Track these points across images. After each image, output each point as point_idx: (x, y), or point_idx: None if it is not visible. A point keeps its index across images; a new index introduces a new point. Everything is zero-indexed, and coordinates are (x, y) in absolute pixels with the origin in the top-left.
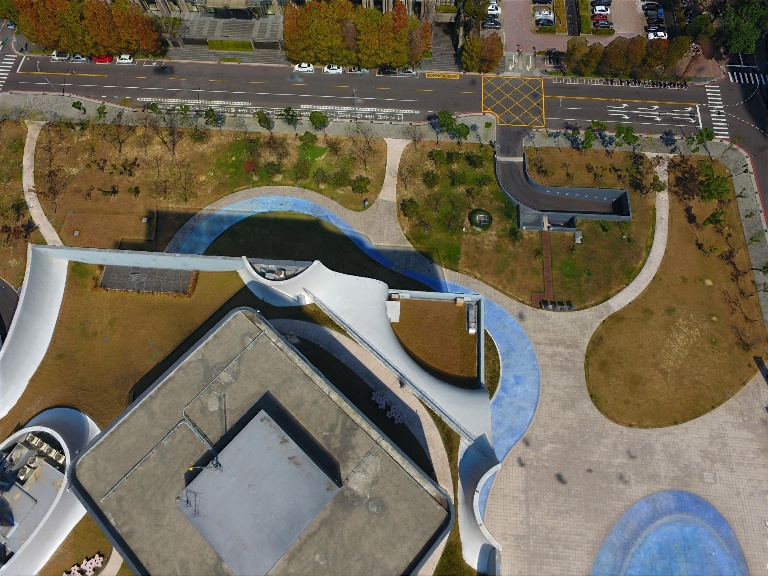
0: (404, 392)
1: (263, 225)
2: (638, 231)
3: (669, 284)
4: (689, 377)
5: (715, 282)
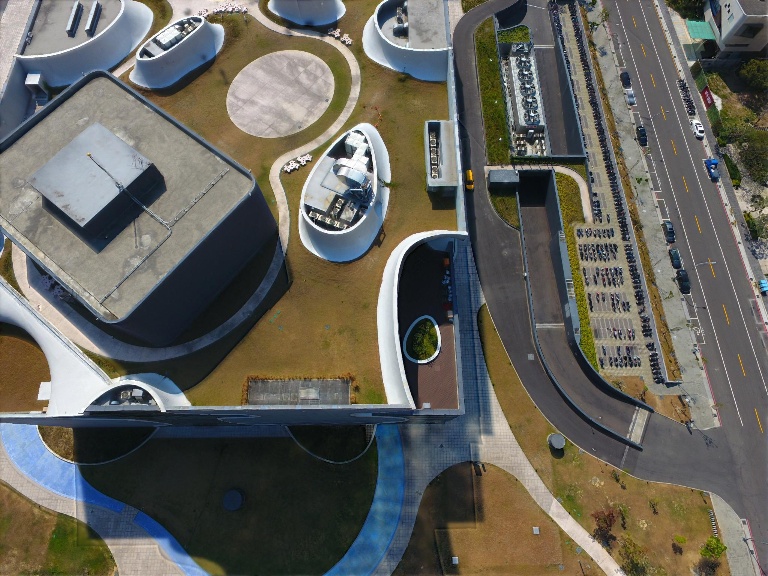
0: (37, 302)
1: (299, 565)
2: None
3: None
4: None
5: None
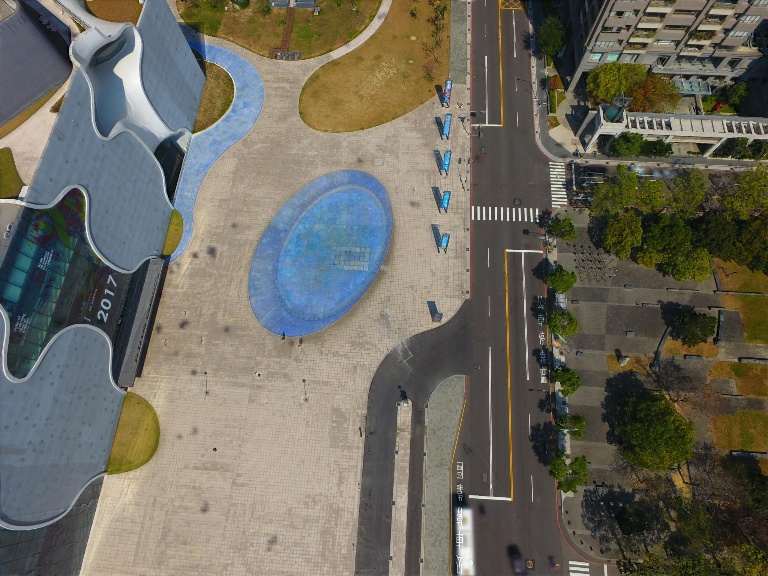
0: (64, 17)
1: None
2: (366, 6)
3: (382, 40)
4: (380, 99)
5: (418, 38)
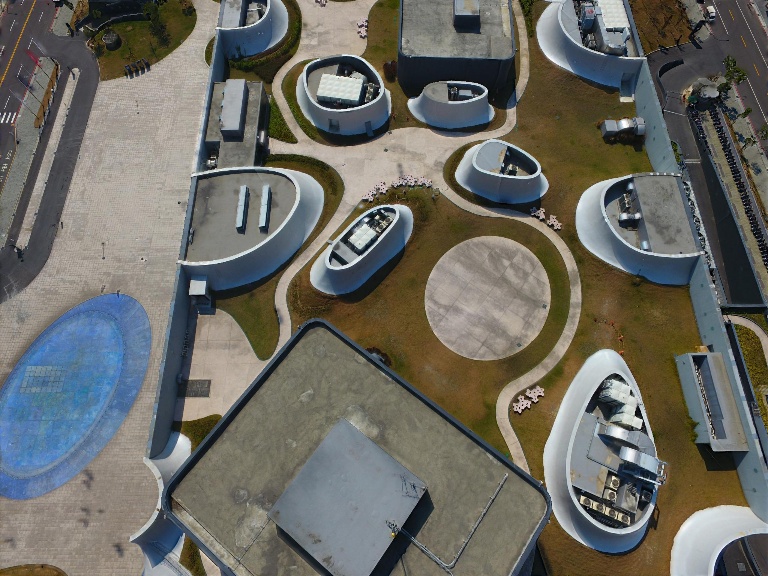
0: None
1: None
2: None
3: None
4: None
5: None
